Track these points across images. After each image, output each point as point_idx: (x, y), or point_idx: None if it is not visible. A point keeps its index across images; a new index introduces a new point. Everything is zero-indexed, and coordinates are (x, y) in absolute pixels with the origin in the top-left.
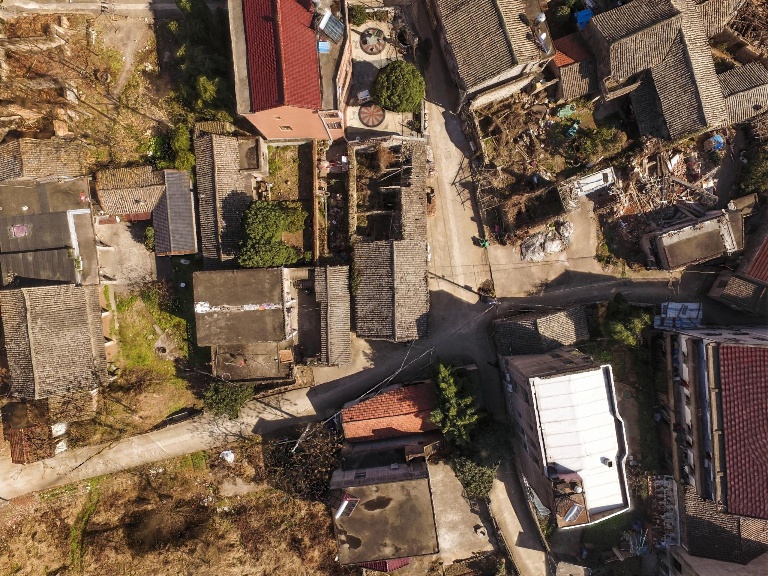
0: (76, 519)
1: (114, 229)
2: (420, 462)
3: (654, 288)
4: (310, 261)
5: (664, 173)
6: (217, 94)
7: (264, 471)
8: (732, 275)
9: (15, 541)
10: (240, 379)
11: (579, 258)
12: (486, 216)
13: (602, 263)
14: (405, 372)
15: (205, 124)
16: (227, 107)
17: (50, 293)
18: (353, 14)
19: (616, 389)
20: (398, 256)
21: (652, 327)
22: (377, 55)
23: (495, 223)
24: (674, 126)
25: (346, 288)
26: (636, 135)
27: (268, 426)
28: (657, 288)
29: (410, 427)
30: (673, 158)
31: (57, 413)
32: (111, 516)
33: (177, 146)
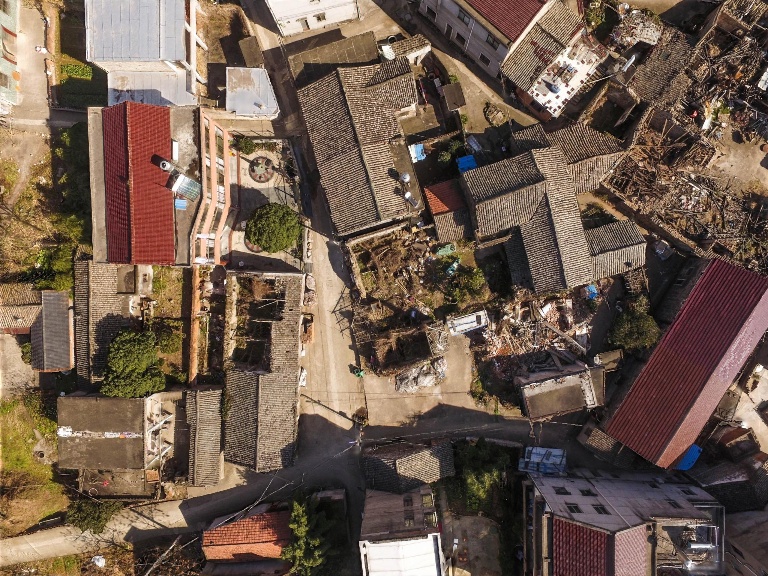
0: None
1: None
2: None
3: (525, 427)
4: (184, 382)
5: (537, 319)
6: (83, 234)
7: None
8: (595, 426)
9: None
10: (107, 495)
11: (453, 392)
12: (362, 347)
13: (475, 399)
14: (277, 491)
15: None
16: None
17: None
18: None
19: (483, 523)
20: (264, 389)
21: (517, 469)
22: (265, 183)
23: (371, 354)
24: (539, 283)
25: (217, 411)
26: (509, 282)
27: (140, 535)
28: (528, 427)
29: (270, 553)
30: (544, 307)
31: None
32: None
33: (55, 269)
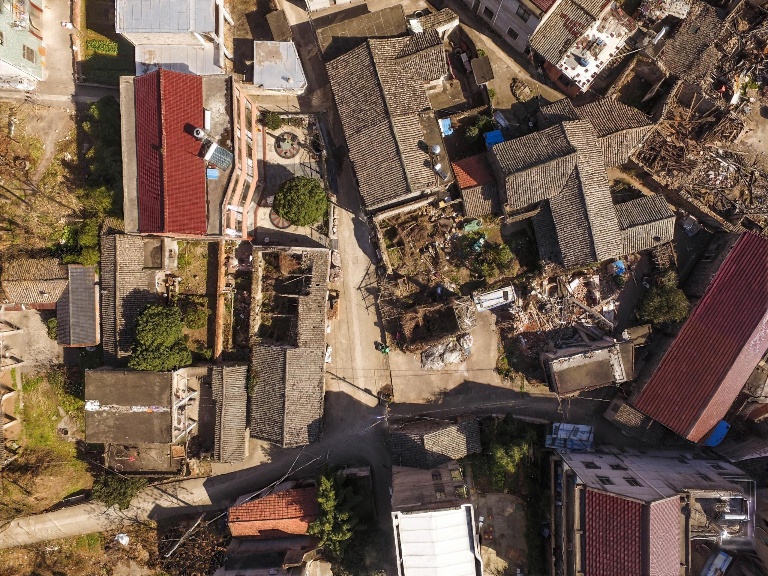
0: None
1: (24, 311)
2: (301, 568)
3: (551, 404)
4: (210, 358)
5: (564, 294)
6: (113, 205)
7: (158, 556)
8: (623, 402)
9: None
10: (132, 471)
11: (479, 369)
12: (388, 323)
13: (501, 376)
14: (301, 469)
15: (114, 220)
16: None
17: None
18: (266, 121)
19: (508, 501)
20: (291, 364)
21: (543, 446)
22: (291, 159)
23: (397, 331)
24: (568, 257)
25: (243, 387)
26: (537, 257)
27: (164, 513)
28: (554, 404)
29: (296, 530)
30: (572, 282)
31: None
32: None
33: (82, 243)
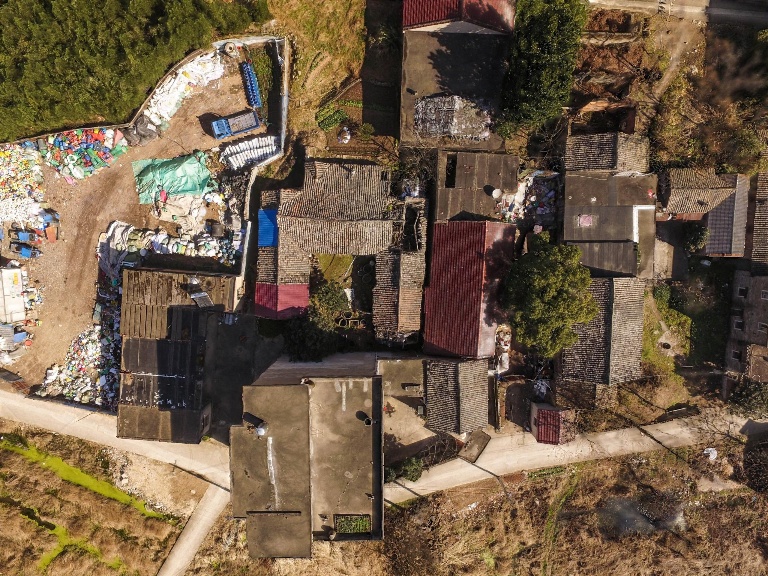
0: (554, 500)
1: None
2: None
3: None
4: None
5: None
6: None
7: (744, 470)
8: None
9: (497, 516)
10: None
11: None
12: None
13: None
14: None
15: (767, 132)
16: None
17: (624, 284)
18: None
19: None
20: None
21: None
22: None
23: None
24: None
25: None
26: None
27: (756, 428)
28: None
29: None
30: None
31: (598, 399)
32: (588, 500)
33: (754, 152)
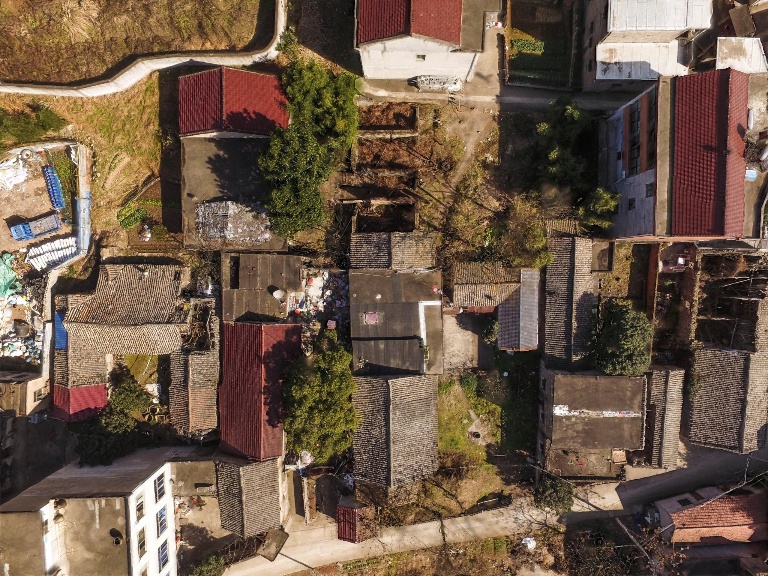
0: None
1: None
2: None
3: None
4: None
5: None
6: (614, 208)
7: (565, 560)
8: None
9: None
10: (570, 476)
11: None
12: None
13: None
14: (719, 475)
15: (556, 222)
16: (610, 217)
17: (406, 384)
18: None
19: None
20: (751, 369)
21: None
22: None
23: None
24: None
25: (680, 392)
26: None
27: (574, 517)
28: None
29: (739, 537)
30: None
31: (392, 497)
32: None
33: (536, 246)
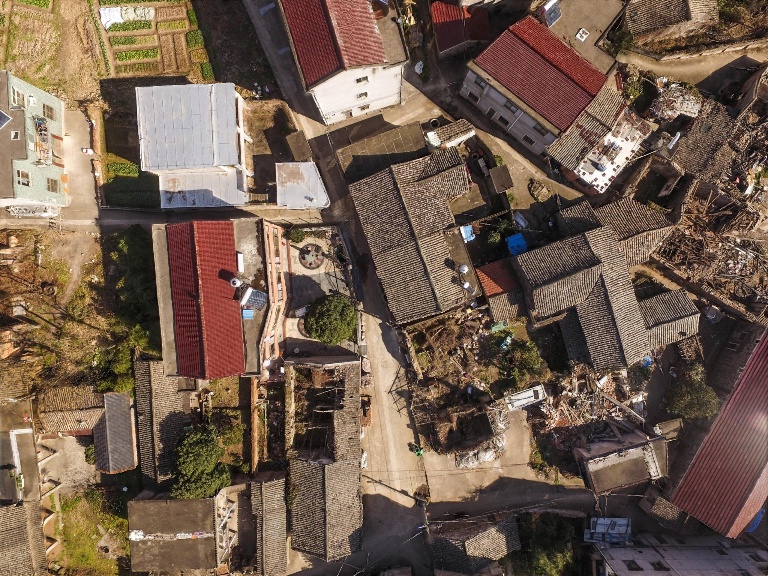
0: None
1: None
2: None
3: (586, 495)
4: (247, 473)
5: (594, 390)
6: (149, 343)
7: None
8: (659, 495)
9: None
10: None
11: (513, 465)
12: (421, 426)
13: (535, 470)
14: (342, 573)
15: None
16: None
17: None
18: None
19: None
20: (330, 479)
21: (582, 540)
22: (316, 269)
23: (430, 433)
24: (598, 361)
25: (282, 500)
26: (565, 356)
27: None
28: (589, 495)
29: None
30: (601, 380)
31: None
32: None
33: (116, 371)
